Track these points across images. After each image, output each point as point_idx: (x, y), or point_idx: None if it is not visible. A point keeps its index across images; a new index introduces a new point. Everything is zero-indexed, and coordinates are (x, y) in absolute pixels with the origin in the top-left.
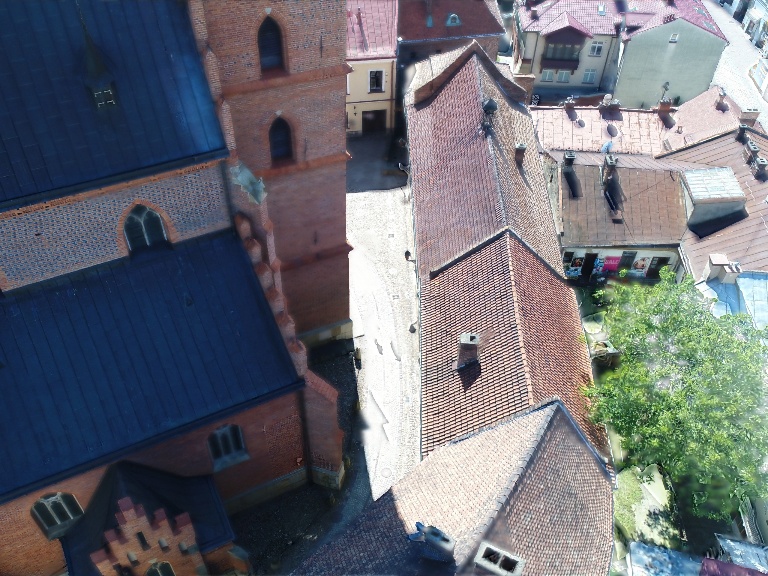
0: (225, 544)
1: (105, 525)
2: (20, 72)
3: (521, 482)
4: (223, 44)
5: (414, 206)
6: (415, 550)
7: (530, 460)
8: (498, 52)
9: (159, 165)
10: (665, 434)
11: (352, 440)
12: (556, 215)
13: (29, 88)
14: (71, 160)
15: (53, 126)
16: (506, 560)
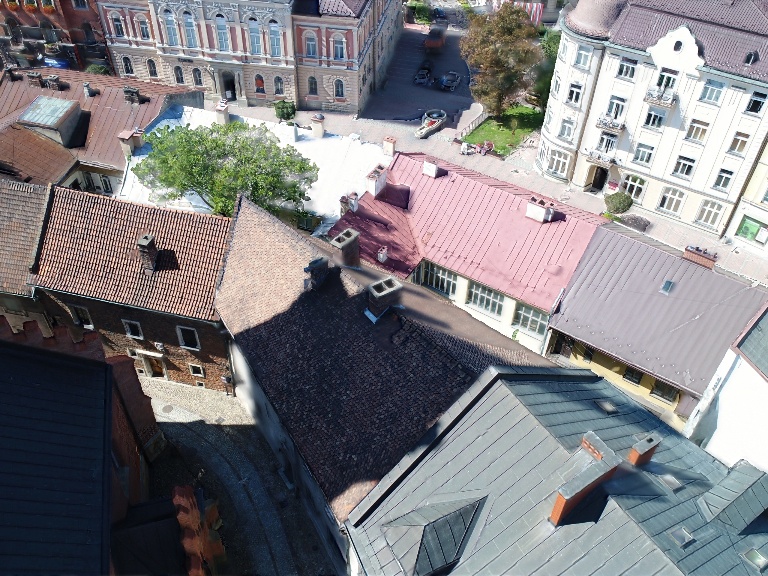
0: None
1: (155, 575)
2: None
3: None
4: None
5: None
6: (307, 300)
7: None
8: None
9: None
10: (272, 182)
11: None
12: None
13: None
14: None
15: None
16: (346, 235)
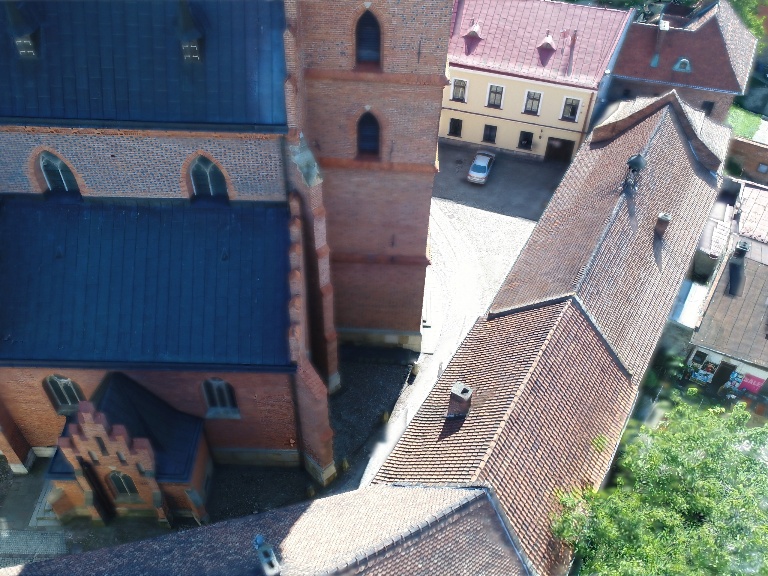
0: (182, 483)
1: None
2: (130, 13)
3: (393, 549)
4: (319, 28)
5: (526, 244)
6: None
7: (416, 532)
8: (763, 115)
9: (221, 124)
10: None
11: (363, 447)
12: (700, 306)
13: (134, 28)
14: (150, 99)
15: (144, 66)
16: None
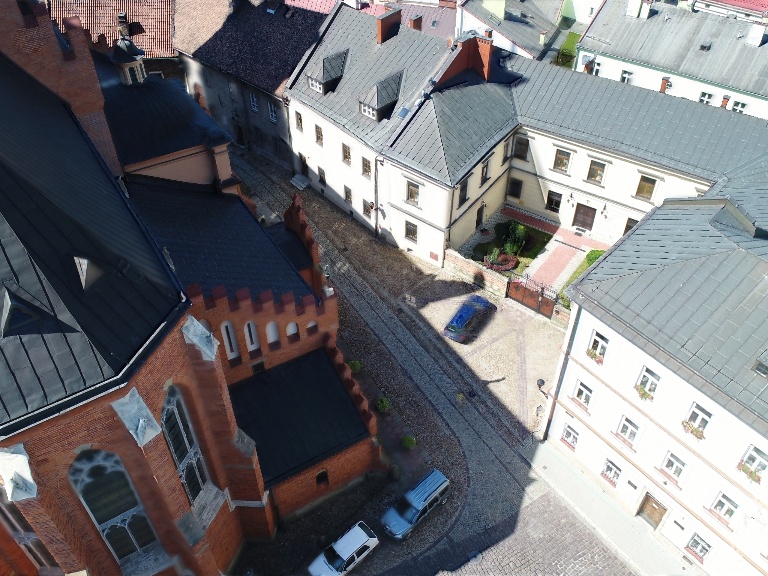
0: None
1: None
2: None
3: None
4: None
5: None
6: (232, 18)
7: None
8: None
9: None
10: None
11: None
12: None
13: None
14: None
15: None
16: None
